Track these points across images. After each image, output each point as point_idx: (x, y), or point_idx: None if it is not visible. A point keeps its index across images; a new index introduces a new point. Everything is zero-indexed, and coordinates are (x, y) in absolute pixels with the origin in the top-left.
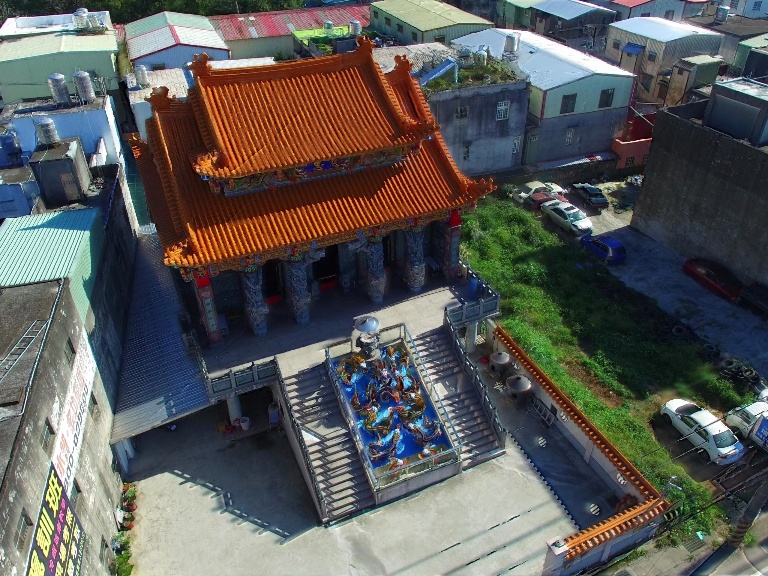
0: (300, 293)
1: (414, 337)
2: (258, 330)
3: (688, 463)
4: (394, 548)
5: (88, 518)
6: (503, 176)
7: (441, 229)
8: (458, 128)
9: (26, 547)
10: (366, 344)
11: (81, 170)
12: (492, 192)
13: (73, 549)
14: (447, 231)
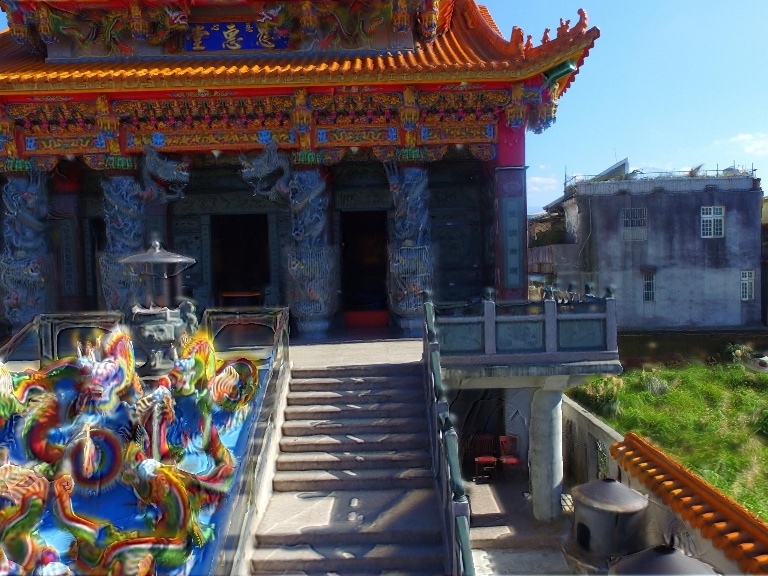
0: (113, 251)
1: (318, 366)
2: (15, 329)
3: None
4: None
5: None
6: (724, 332)
7: (491, 204)
8: (629, 243)
9: None
10: (137, 318)
11: None
12: (703, 359)
13: None
14: (494, 187)
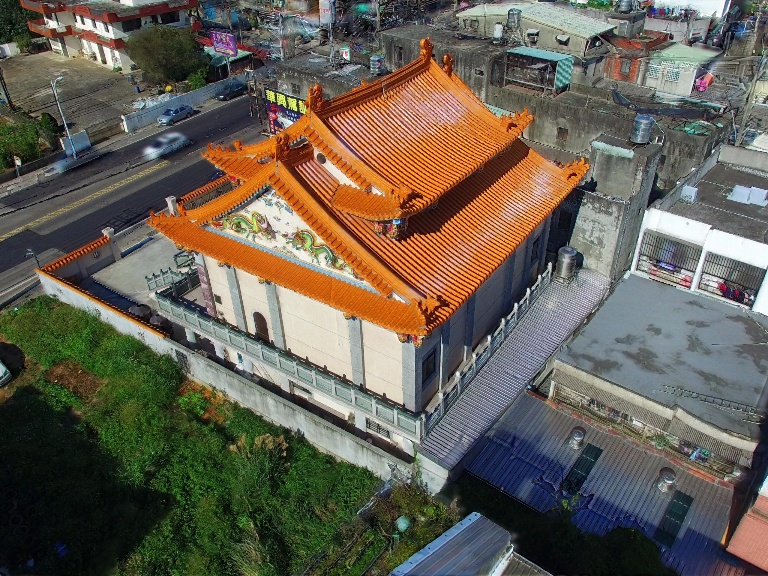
0: None
1: None
2: None
3: (4, 350)
4: None
5: None
6: None
7: None
8: None
9: None
10: None
11: (617, 176)
12: None
13: None
14: None
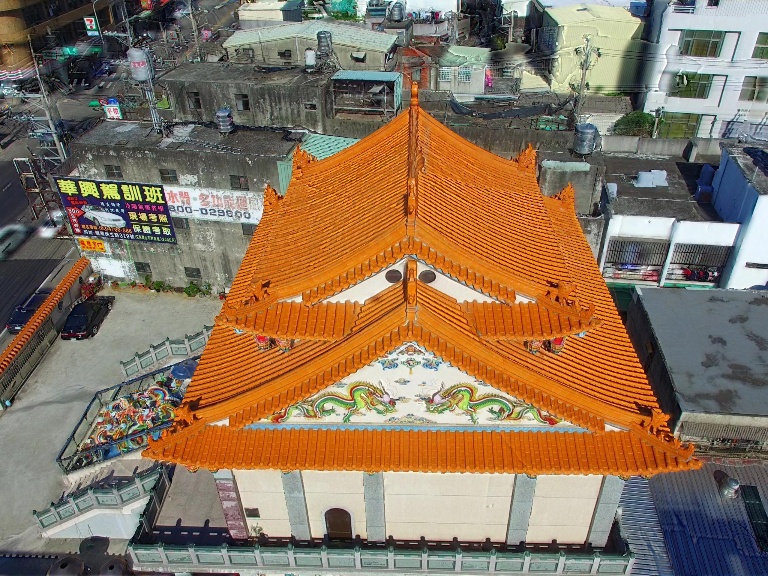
0: None
1: None
2: None
3: None
4: (67, 413)
5: (189, 245)
6: None
7: None
8: None
9: (114, 178)
10: None
11: None
12: None
13: (157, 229)
14: None
